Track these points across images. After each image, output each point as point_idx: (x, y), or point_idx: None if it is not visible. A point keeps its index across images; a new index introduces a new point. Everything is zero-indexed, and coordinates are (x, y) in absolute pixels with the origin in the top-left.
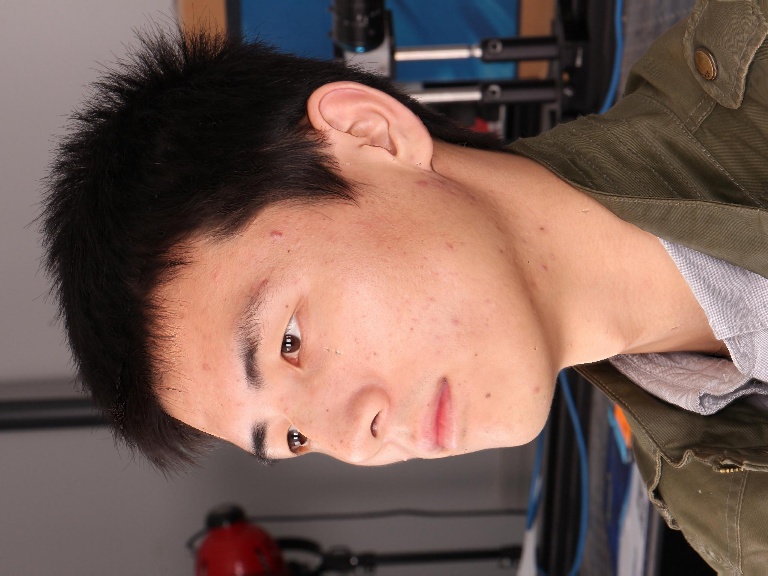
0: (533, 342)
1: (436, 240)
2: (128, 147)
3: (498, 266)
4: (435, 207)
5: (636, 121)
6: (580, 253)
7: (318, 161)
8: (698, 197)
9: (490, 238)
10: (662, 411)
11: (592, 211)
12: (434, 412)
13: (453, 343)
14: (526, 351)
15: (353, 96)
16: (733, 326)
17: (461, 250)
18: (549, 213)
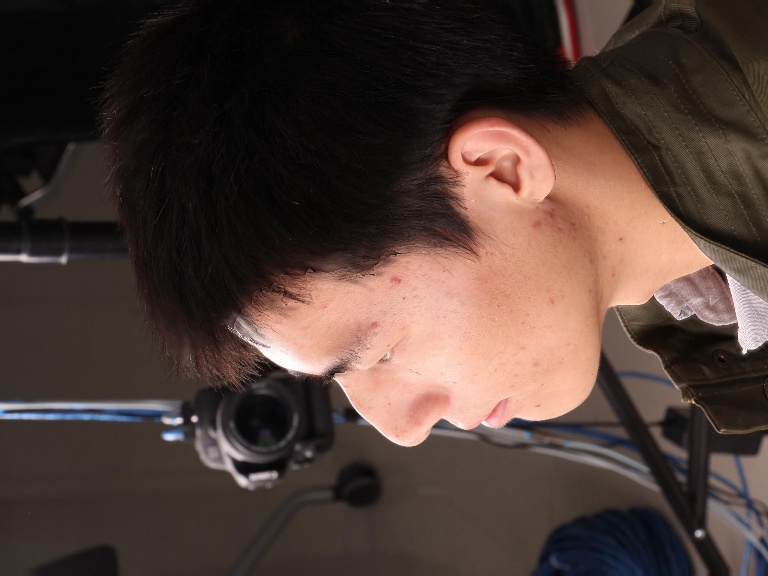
0: (593, 369)
1: (541, 296)
2: (260, 158)
3: (585, 310)
4: (546, 256)
5: (733, 139)
6: (644, 253)
7: (447, 201)
8: None
9: (585, 282)
10: None
11: (669, 223)
12: None
13: (527, 380)
14: (585, 379)
15: (494, 134)
16: (759, 340)
17: (560, 304)
18: (631, 225)
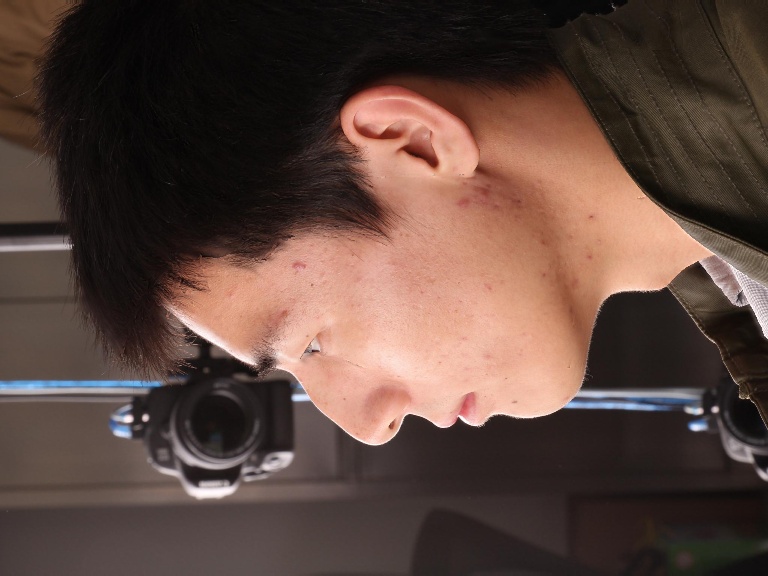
0: (568, 361)
1: (474, 282)
2: (135, 136)
3: (539, 296)
4: (476, 237)
5: (711, 102)
6: (630, 232)
7: (349, 178)
8: (767, 200)
9: (533, 265)
10: (697, 279)
11: (648, 198)
12: (456, 414)
13: (483, 373)
14: (559, 372)
15: (393, 103)
16: None
17: (500, 290)
18: (601, 201)
